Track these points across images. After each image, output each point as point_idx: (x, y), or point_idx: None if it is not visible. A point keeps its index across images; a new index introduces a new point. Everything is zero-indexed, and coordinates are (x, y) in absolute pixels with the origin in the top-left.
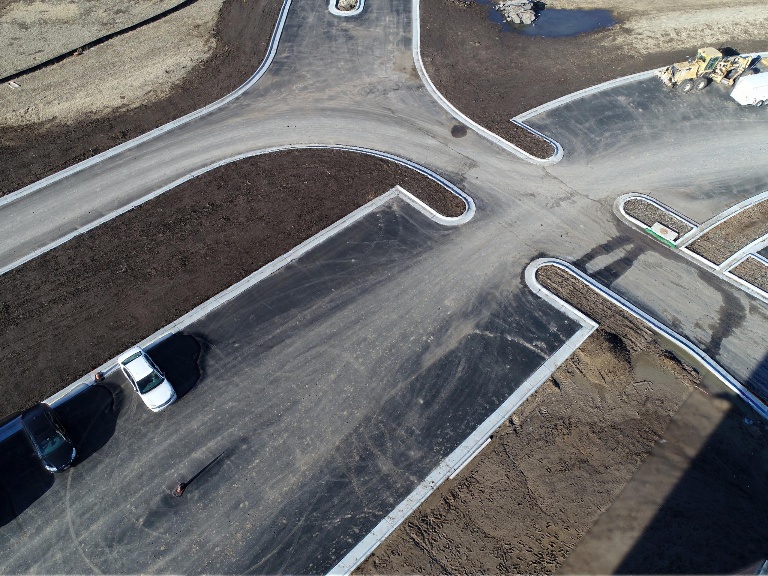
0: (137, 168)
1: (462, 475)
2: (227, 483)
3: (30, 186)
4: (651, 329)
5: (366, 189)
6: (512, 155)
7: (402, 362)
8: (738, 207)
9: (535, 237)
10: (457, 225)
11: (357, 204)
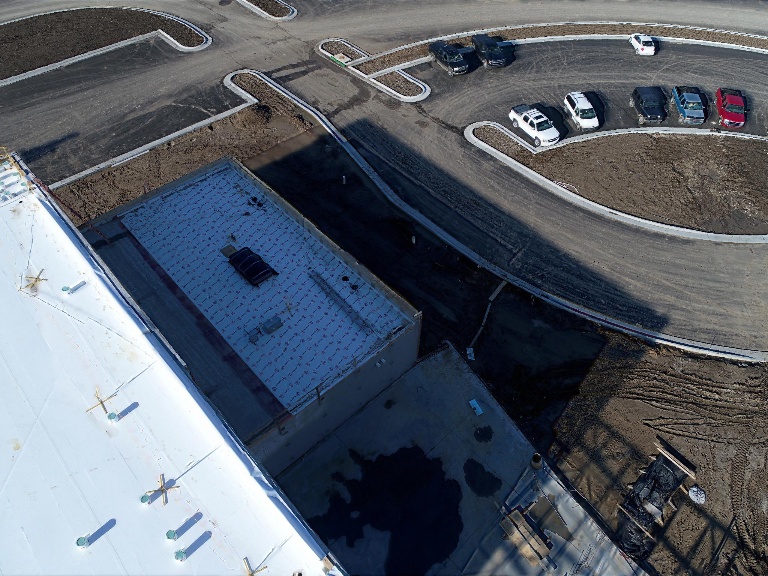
0: None
1: (121, 166)
2: None
3: None
4: (295, 105)
5: (135, 31)
6: (257, 15)
7: (112, 117)
8: (406, 46)
9: (246, 59)
10: (192, 51)
11: (124, 38)
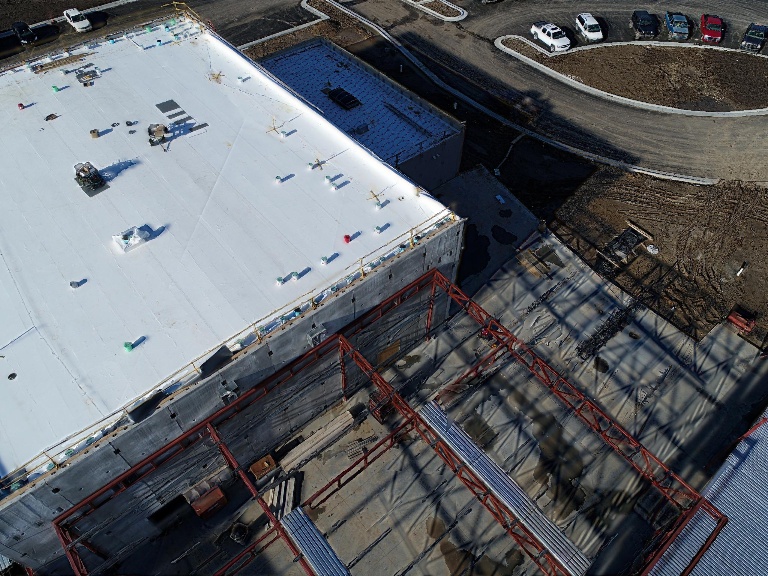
0: None
1: None
2: None
3: None
4: (359, 21)
5: None
6: None
7: (216, 26)
8: None
9: None
10: None
11: None
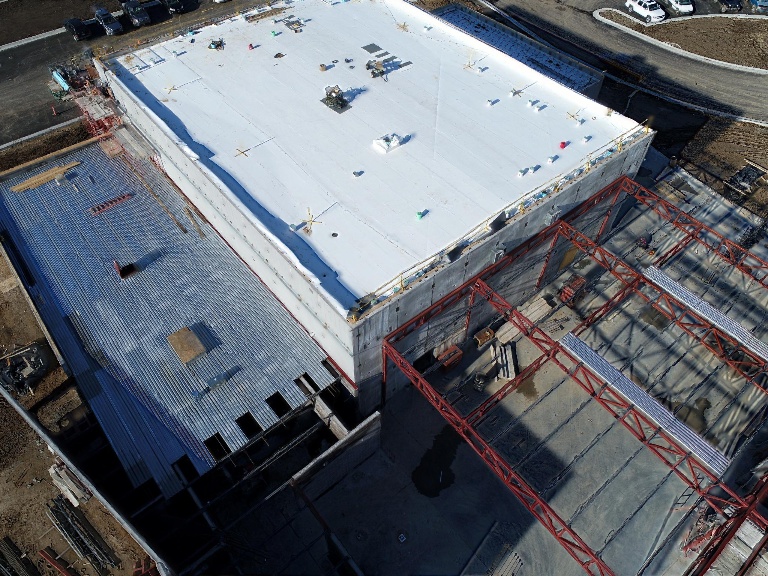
0: None
1: None
2: None
3: None
4: None
5: None
6: None
7: None
8: None
9: None
10: None
11: None
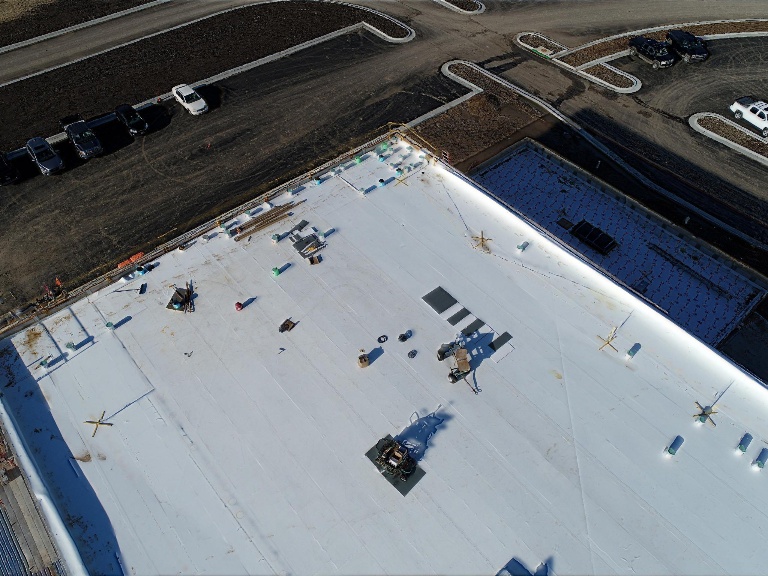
0: (183, 9)
1: None
2: (238, 146)
3: (109, 16)
4: (518, 94)
5: (341, 22)
6: (448, 9)
7: (352, 103)
8: (601, 40)
9: (453, 50)
10: (401, 43)
11: (333, 29)
